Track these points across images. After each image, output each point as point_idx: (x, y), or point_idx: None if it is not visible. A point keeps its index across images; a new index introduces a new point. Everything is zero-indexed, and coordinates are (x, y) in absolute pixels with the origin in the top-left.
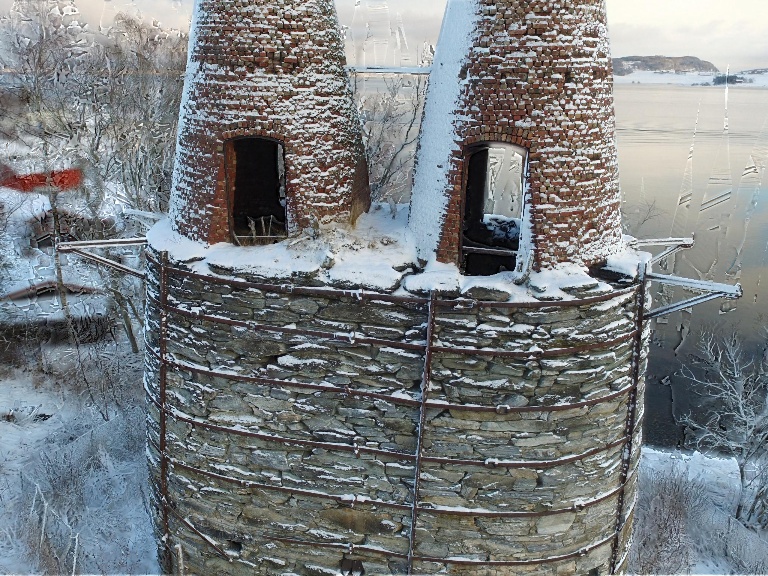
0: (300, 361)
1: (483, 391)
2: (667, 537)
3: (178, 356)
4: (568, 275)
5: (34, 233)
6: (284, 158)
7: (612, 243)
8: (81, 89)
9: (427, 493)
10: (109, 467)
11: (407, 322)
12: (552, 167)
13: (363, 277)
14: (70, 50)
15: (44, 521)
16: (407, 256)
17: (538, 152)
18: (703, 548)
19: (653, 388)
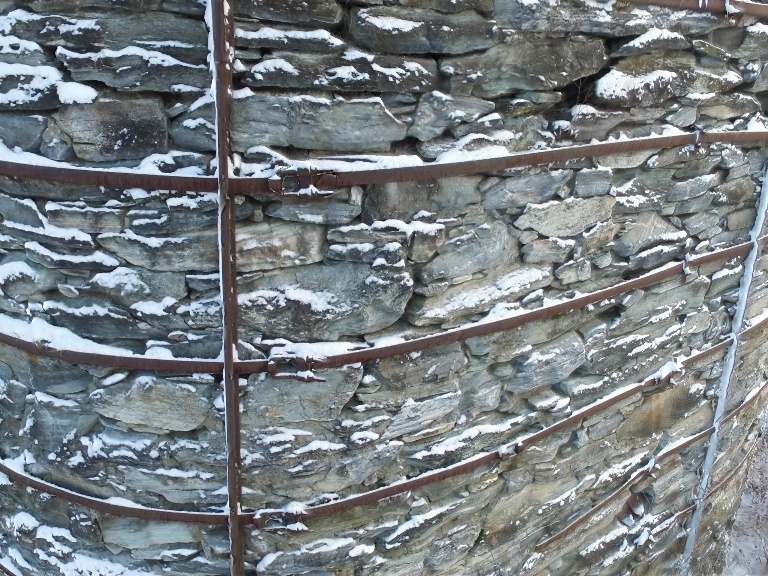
0: (638, 80)
1: None
2: None
3: (283, 154)
4: None
5: None
6: None
7: None
8: None
9: None
10: None
11: None
12: None
13: None
14: None
15: None
16: None
17: None
18: None
19: None
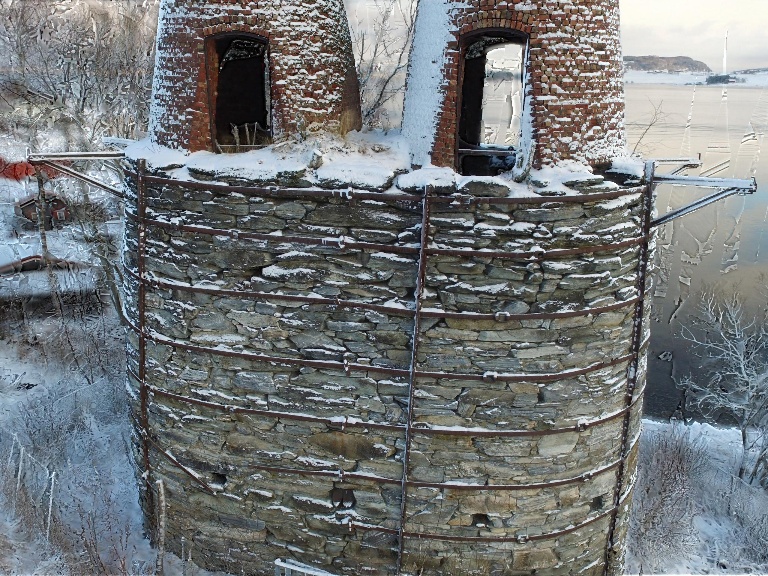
0: (286, 271)
1: (481, 297)
2: (671, 482)
3: (157, 274)
4: (571, 172)
5: (18, 198)
6: (269, 57)
7: (617, 145)
8: (65, 47)
9: (422, 412)
10: (93, 429)
11: (400, 224)
12: (554, 55)
13: (353, 175)
14: (53, 6)
15: (20, 466)
16: (400, 162)
17: (539, 38)
18: (705, 507)
19: (651, 363)
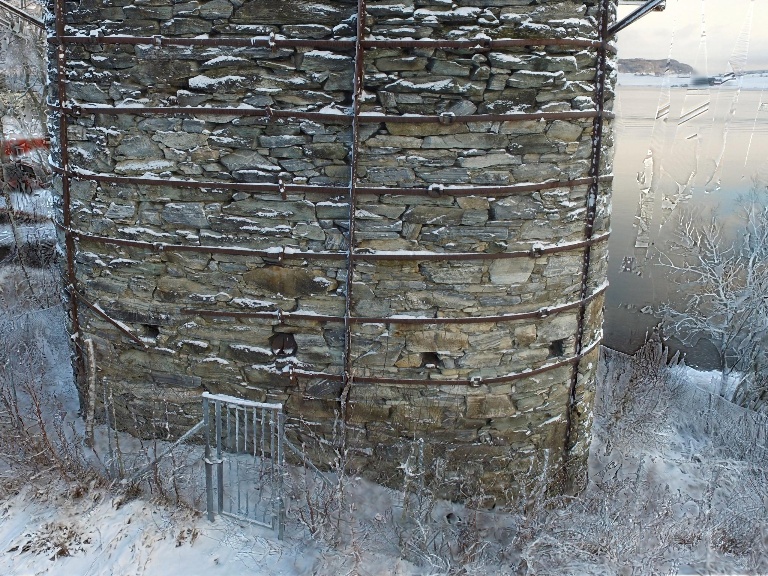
0: (214, 80)
1: (424, 96)
2: None
3: (79, 102)
4: None
5: None
6: None
7: None
8: None
9: (364, 236)
10: (46, 353)
11: (334, 15)
12: None
13: None
14: None
15: None
16: None
17: None
18: (683, 424)
19: (632, 316)
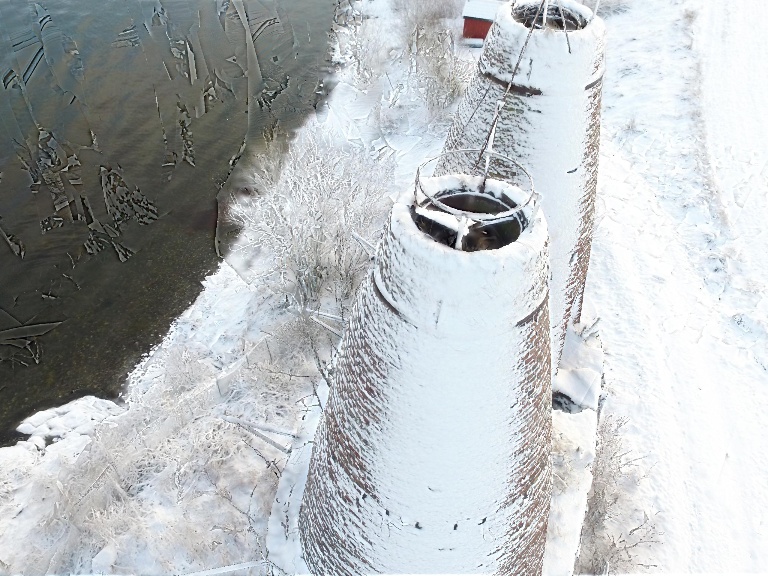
0: None
1: None
2: None
3: None
4: None
5: None
6: None
7: None
8: None
9: None
10: None
11: None
12: None
13: None
14: None
15: None
16: None
17: None
18: None
19: (94, 264)
